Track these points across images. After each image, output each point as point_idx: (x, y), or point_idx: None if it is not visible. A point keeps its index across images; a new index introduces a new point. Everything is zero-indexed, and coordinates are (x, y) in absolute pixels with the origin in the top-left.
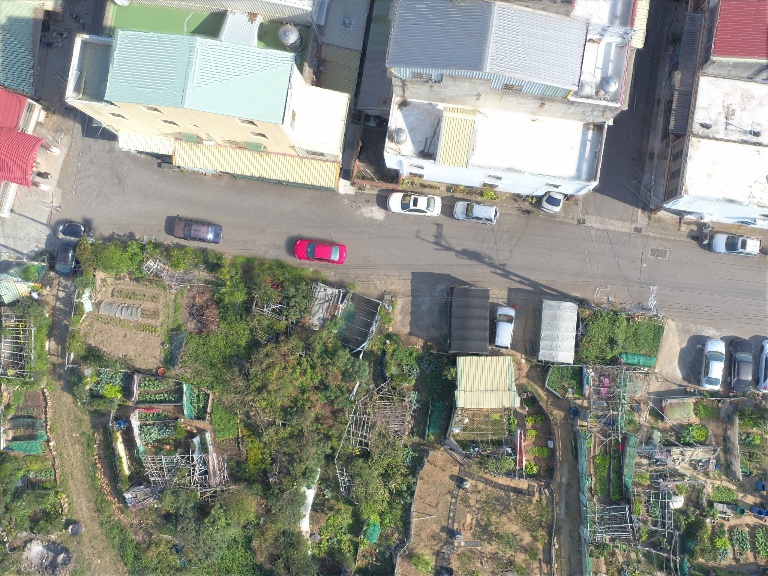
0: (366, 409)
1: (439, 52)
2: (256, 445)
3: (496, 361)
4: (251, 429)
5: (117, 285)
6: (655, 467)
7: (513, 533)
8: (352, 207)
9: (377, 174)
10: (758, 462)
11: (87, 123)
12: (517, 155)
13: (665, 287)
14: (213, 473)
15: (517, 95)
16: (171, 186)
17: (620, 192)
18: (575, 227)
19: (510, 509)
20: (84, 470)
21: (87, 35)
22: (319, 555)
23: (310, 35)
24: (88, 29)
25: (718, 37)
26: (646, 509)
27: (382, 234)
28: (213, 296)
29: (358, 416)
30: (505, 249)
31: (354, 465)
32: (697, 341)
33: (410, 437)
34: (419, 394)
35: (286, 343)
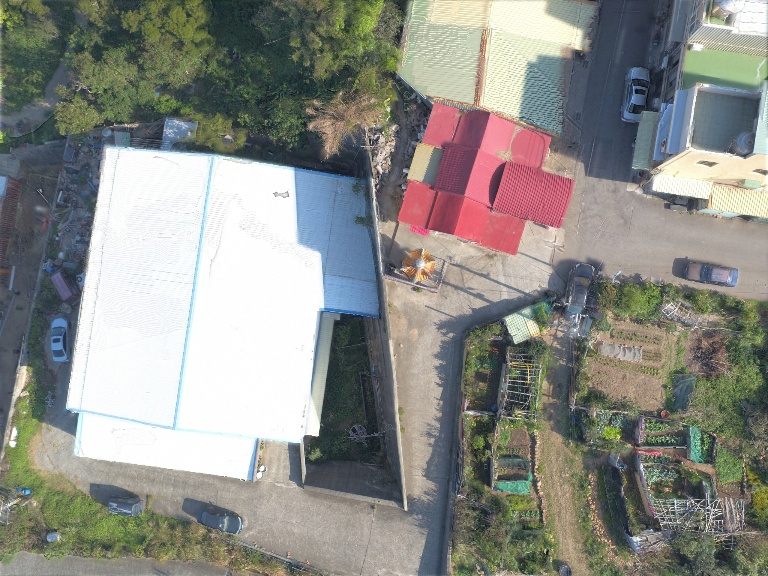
0: None
1: None
2: (763, 489)
3: None
4: (757, 473)
5: (616, 326)
6: None
7: None
8: None
9: None
10: None
11: (591, 162)
12: None
13: None
14: (730, 518)
15: None
16: (679, 228)
17: None
18: None
19: None
20: (574, 511)
21: (707, 84)
22: None
23: None
24: (591, 67)
25: None
26: None
27: None
28: (723, 339)
29: None
30: None
31: None
32: None
33: None
34: None
35: None
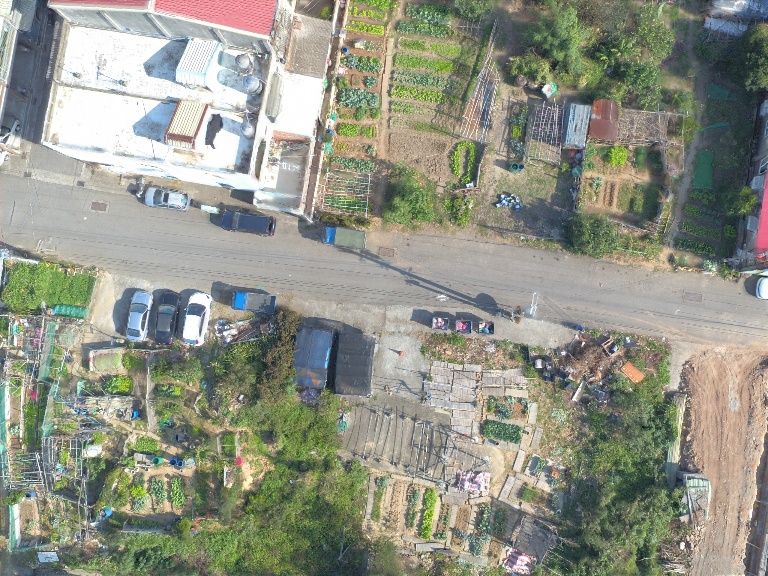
0: None
1: None
2: None
3: None
4: None
5: None
6: (84, 417)
7: None
8: None
9: None
10: None
11: None
12: None
13: (103, 240)
14: None
15: None
16: None
17: None
18: (21, 180)
19: None
20: None
21: None
22: None
23: None
24: None
25: None
26: None
27: None
28: None
29: None
30: None
31: None
32: (132, 294)
33: None
34: None
35: None
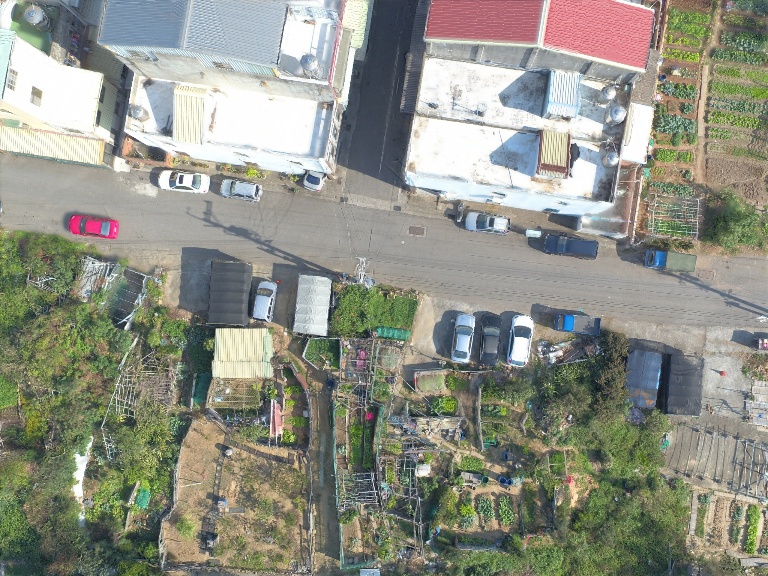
0: (131, 378)
1: (139, 30)
2: (34, 413)
3: (252, 333)
4: (30, 398)
5: None
6: (408, 437)
7: (275, 500)
8: (127, 184)
9: (151, 153)
10: (503, 433)
11: None
12: (254, 133)
13: (422, 264)
14: None
15: (234, 73)
16: None
17: (381, 172)
18: (337, 205)
19: (272, 477)
20: None
21: None
22: (92, 520)
23: (59, 16)
24: None
25: (431, 19)
26: (398, 477)
27: (154, 210)
28: None
29: (123, 385)
30: (271, 226)
31: (118, 432)
32: (451, 316)
33: (178, 406)
34: (186, 365)
35: (55, 314)
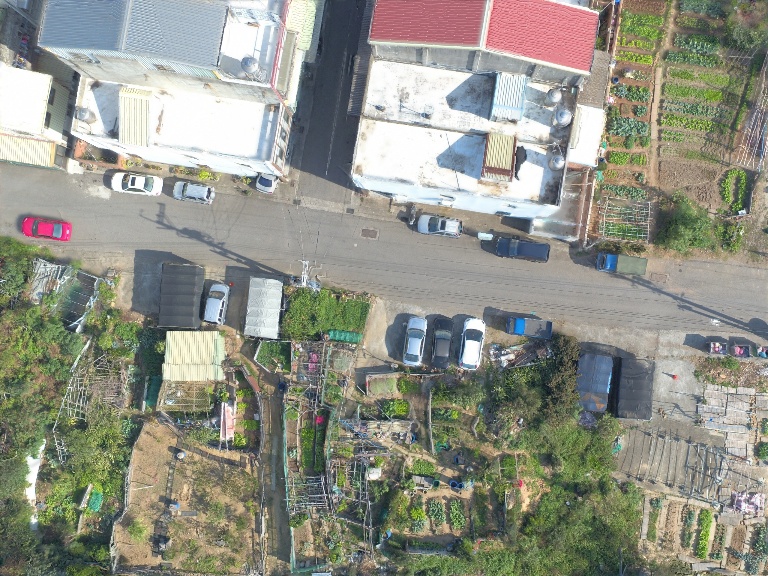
0: (82, 381)
1: (77, 32)
2: None
3: (203, 336)
4: None
5: None
6: (359, 440)
7: (227, 503)
8: (80, 186)
9: (104, 155)
10: (454, 436)
11: None
12: (201, 135)
13: (374, 266)
14: None
15: (176, 76)
16: None
17: (334, 174)
18: (290, 208)
19: (224, 480)
20: None
21: None
22: (45, 523)
23: (7, 18)
24: None
25: (375, 22)
26: (350, 481)
27: (108, 213)
28: None
29: (75, 388)
30: (224, 228)
31: (69, 435)
32: (404, 319)
33: (130, 409)
34: (139, 368)
35: None
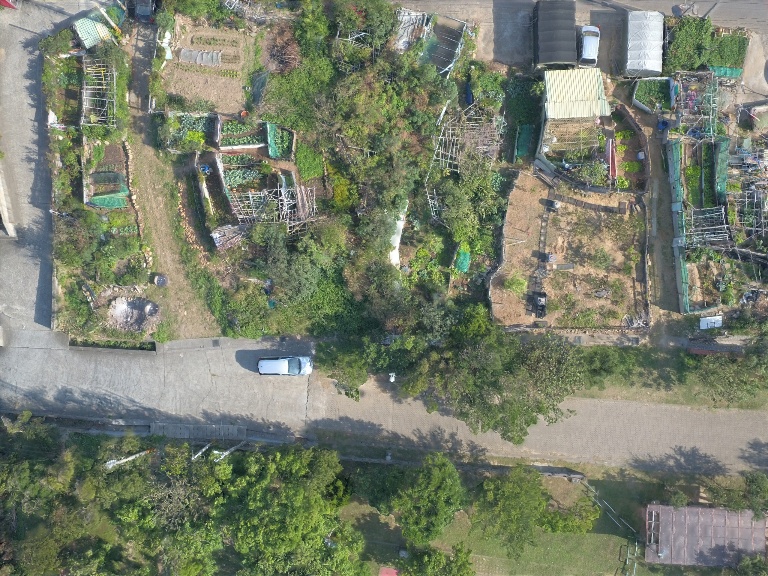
0: (455, 130)
1: None
2: (342, 182)
3: (584, 73)
4: (337, 166)
5: (196, 32)
6: (746, 176)
7: None
8: None
9: None
10: None
11: None
12: None
13: (748, 1)
14: (302, 205)
15: None
16: None
17: None
18: None
19: (601, 229)
20: (168, 221)
21: None
22: (410, 288)
23: None
24: None
25: None
26: (739, 218)
27: None
28: (294, 34)
29: (447, 138)
30: None
31: (445, 186)
32: None
33: (498, 162)
34: (505, 119)
35: (372, 68)
